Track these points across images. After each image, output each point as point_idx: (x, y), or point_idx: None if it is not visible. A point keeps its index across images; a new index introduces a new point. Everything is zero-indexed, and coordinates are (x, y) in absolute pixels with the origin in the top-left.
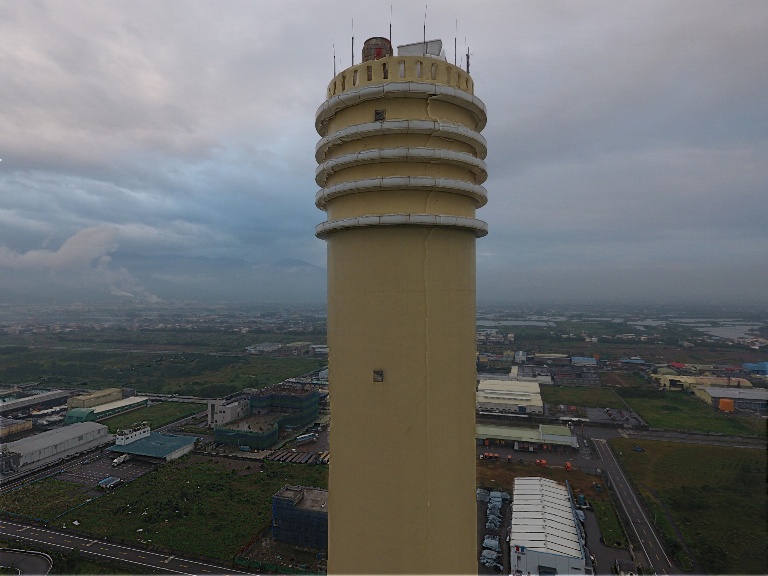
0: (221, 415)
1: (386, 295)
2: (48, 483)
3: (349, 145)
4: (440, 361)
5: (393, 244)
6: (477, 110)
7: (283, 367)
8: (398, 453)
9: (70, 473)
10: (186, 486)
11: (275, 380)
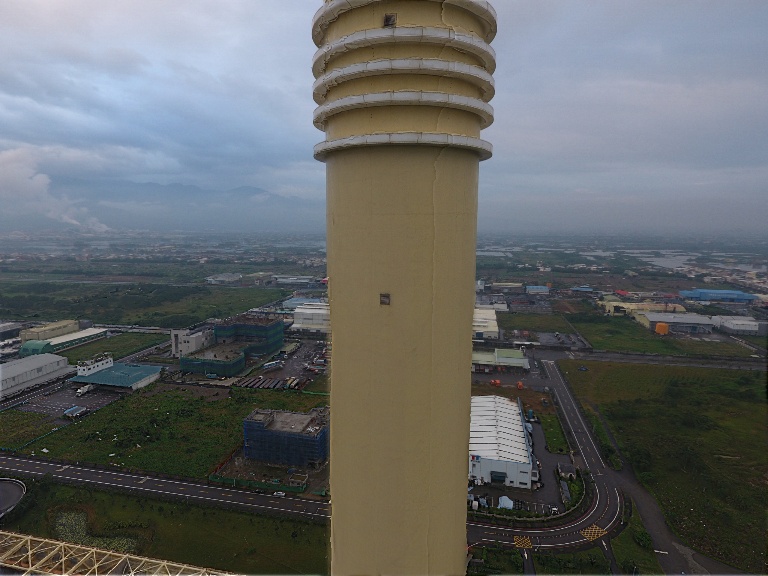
0: (185, 345)
1: (394, 218)
2: (10, 414)
3: (355, 53)
4: (445, 284)
5: (402, 164)
6: (491, 19)
7: (245, 297)
8: (403, 372)
9: (32, 404)
10: (155, 413)
11: (238, 310)
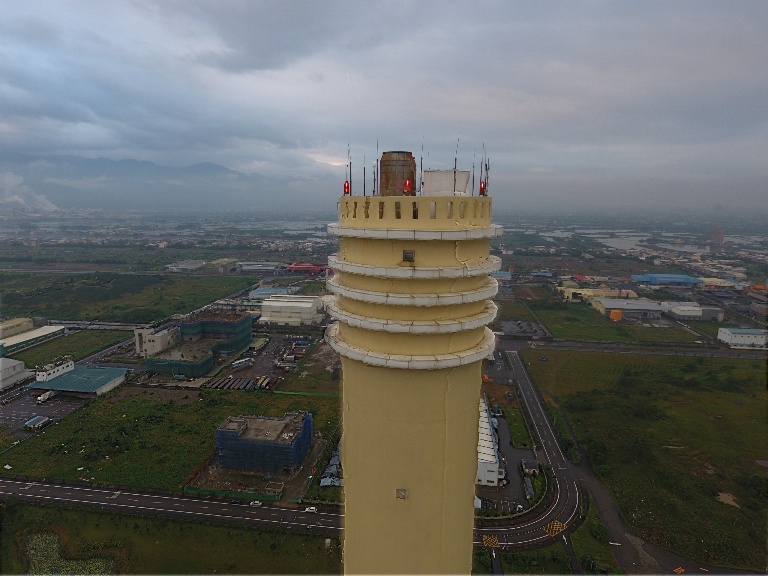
0: (150, 344)
1: (410, 425)
2: None
3: (374, 281)
4: (455, 475)
5: (418, 381)
6: (497, 237)
7: (210, 287)
8: (417, 554)
9: None
10: (123, 420)
11: (203, 302)
